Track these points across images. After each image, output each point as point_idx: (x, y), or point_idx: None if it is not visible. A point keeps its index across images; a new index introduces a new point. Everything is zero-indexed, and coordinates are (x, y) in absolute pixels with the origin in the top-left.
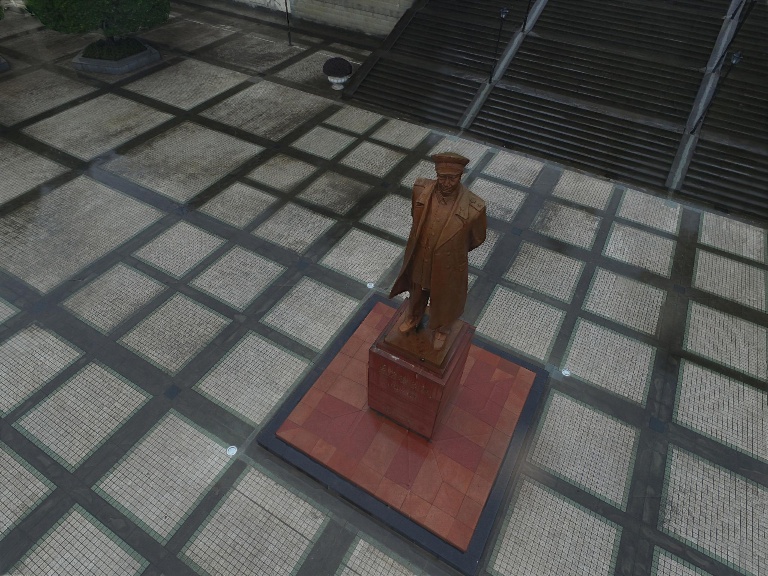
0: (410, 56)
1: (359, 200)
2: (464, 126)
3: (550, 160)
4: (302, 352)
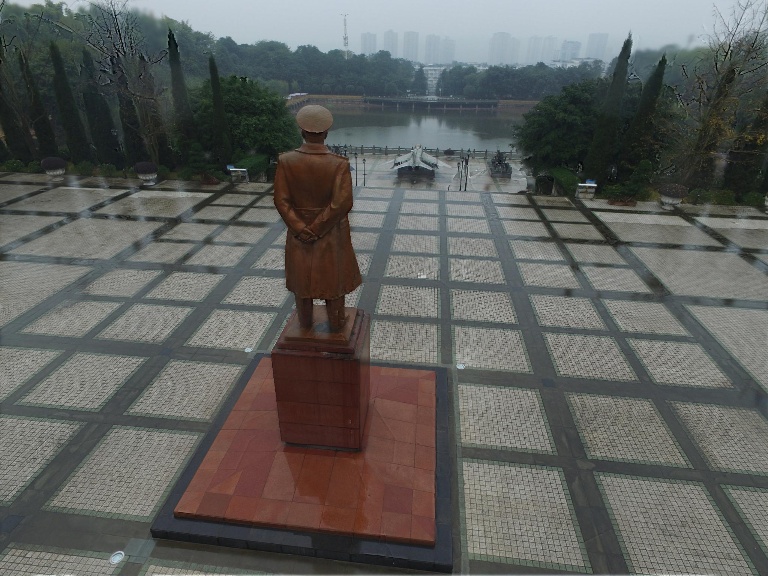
0: None
1: None
2: None
3: None
4: (480, 452)
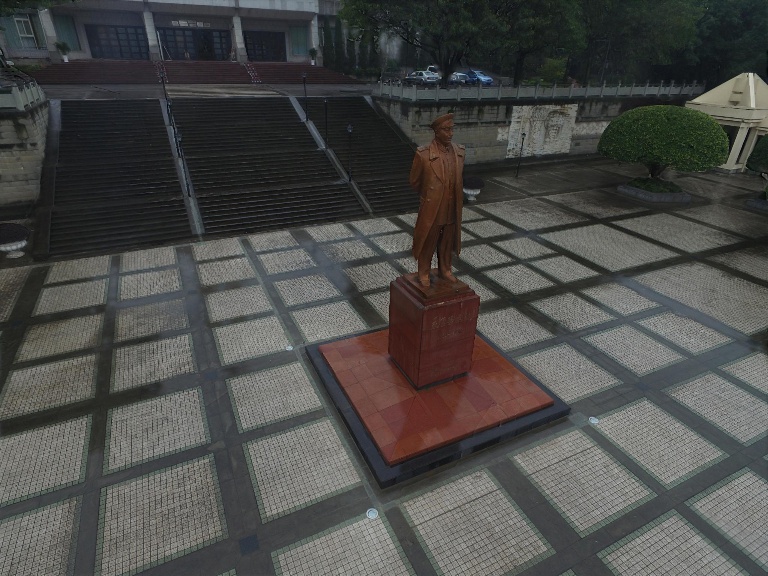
0: (83, 203)
1: (186, 311)
2: (200, 232)
3: (288, 227)
4: (311, 418)
